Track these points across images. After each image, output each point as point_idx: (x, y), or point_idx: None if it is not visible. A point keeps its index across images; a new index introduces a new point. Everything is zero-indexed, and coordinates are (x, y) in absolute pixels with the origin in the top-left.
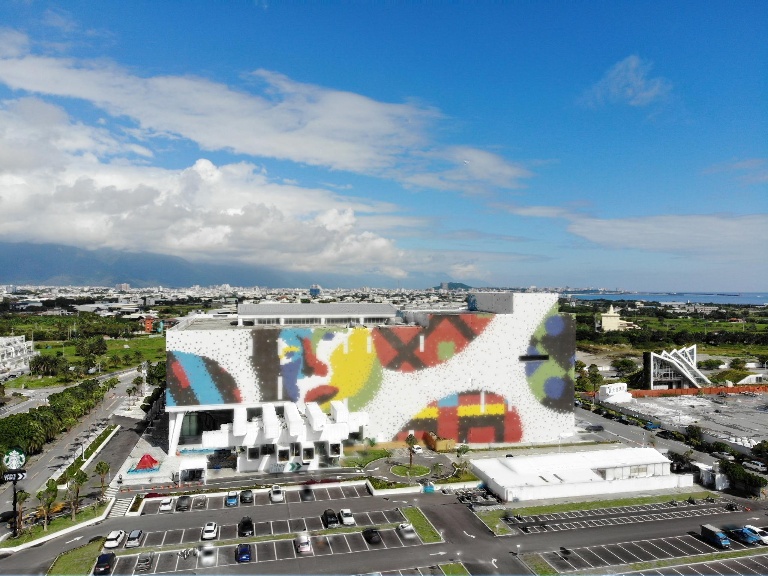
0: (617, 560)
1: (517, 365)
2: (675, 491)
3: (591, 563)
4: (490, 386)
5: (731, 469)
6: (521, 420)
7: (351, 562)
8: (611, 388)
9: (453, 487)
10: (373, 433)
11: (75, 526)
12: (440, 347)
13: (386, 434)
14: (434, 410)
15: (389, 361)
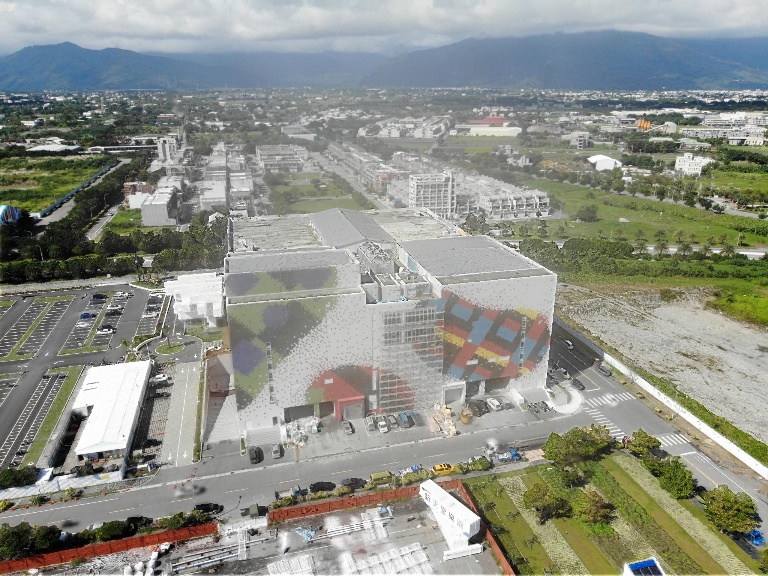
0: None
1: None
2: (49, 454)
3: None
4: None
5: None
6: None
7: None
8: (431, 495)
9: None
10: None
11: None
12: None
13: None
14: None
15: None
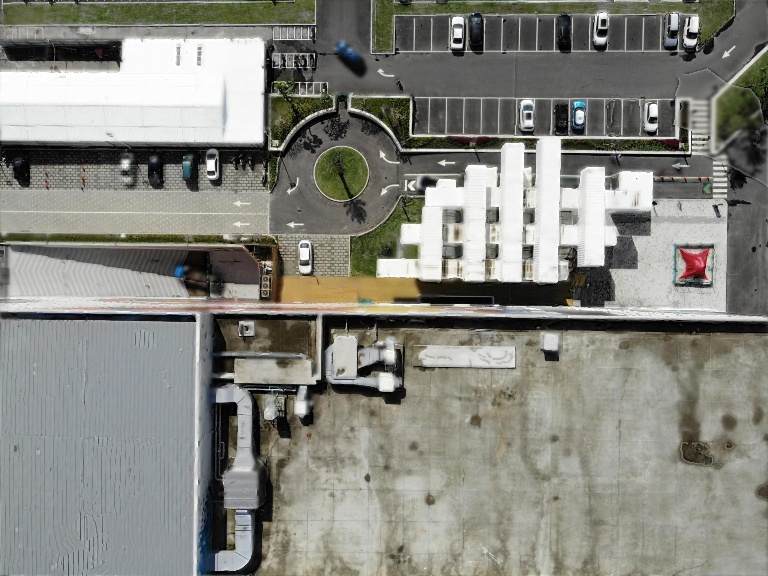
0: None
1: None
2: (41, 34)
3: None
4: None
5: None
6: None
7: None
8: None
9: None
10: None
11: (737, 78)
12: None
13: None
14: None
15: None
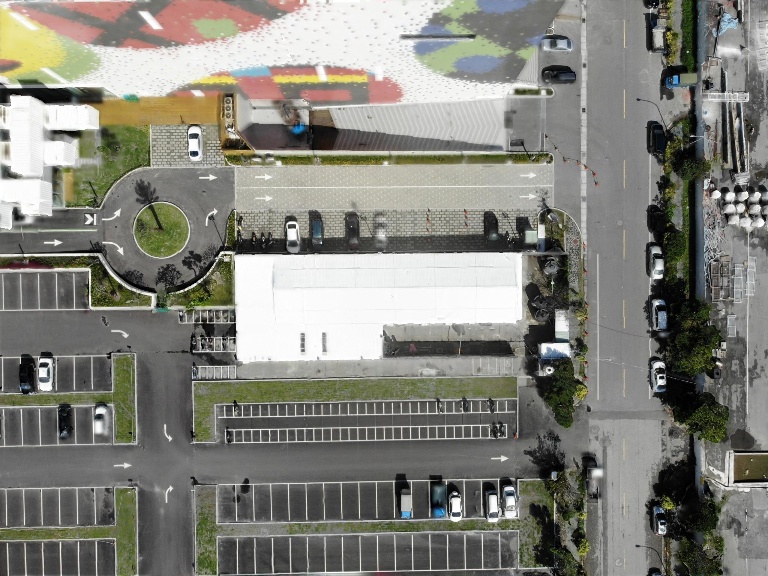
0: (283, 514)
1: (394, 44)
2: (476, 368)
3: (256, 514)
4: (334, 61)
5: (550, 394)
6: (401, 87)
7: (37, 465)
8: None
9: (195, 309)
10: (127, 90)
11: None
12: (199, 23)
13: (151, 91)
14: (226, 77)
15: (92, 37)
